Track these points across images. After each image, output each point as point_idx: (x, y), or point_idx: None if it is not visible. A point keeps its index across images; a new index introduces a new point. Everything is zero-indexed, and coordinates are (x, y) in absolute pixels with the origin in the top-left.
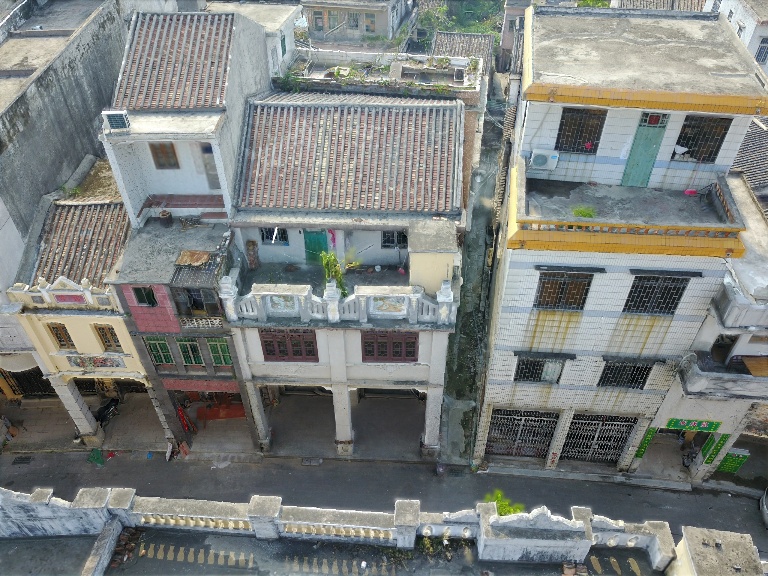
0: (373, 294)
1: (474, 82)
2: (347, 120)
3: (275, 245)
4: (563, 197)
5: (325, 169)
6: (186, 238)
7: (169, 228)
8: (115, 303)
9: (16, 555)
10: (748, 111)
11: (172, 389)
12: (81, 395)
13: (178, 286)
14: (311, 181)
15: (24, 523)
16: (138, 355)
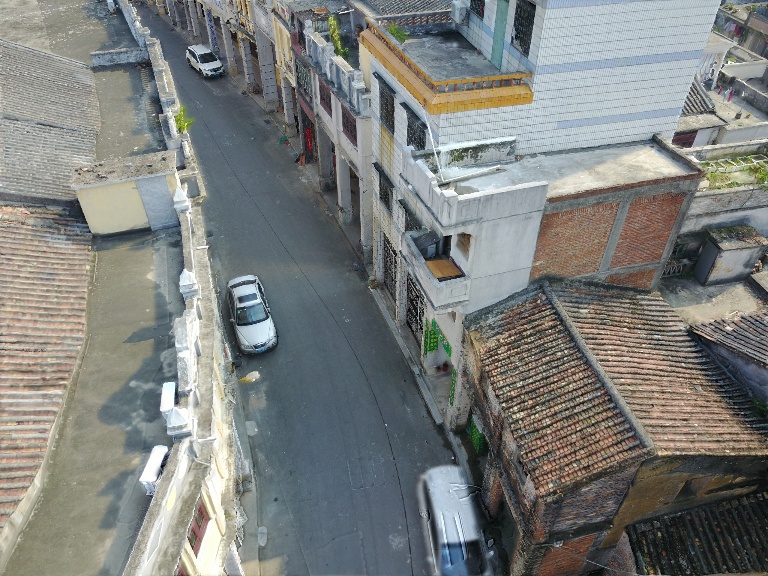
0: (336, 61)
1: None
2: None
3: None
4: (446, 46)
5: None
6: (337, 5)
7: None
8: None
9: None
10: None
11: None
12: None
13: None
14: None
15: None
16: None
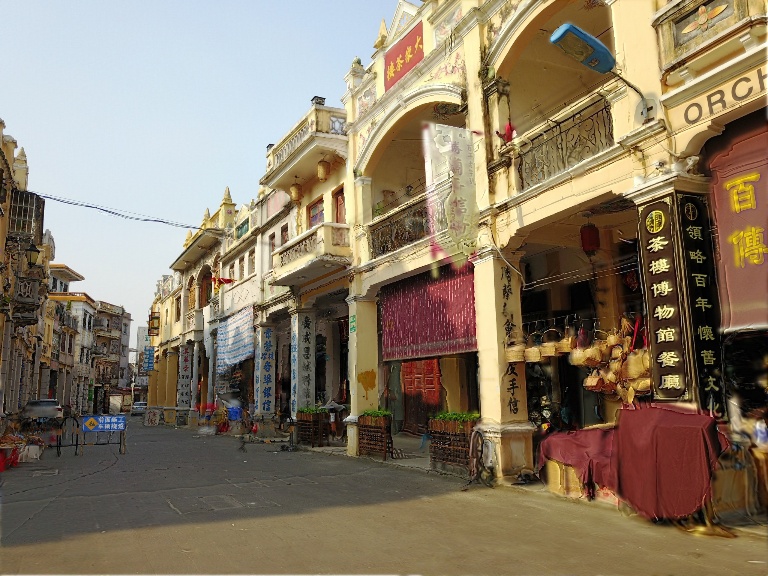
0: None
1: None
2: None
3: None
4: None
5: None
6: None
7: None
8: None
9: None
10: None
11: (51, 368)
12: None
13: None
14: None
15: None
16: None
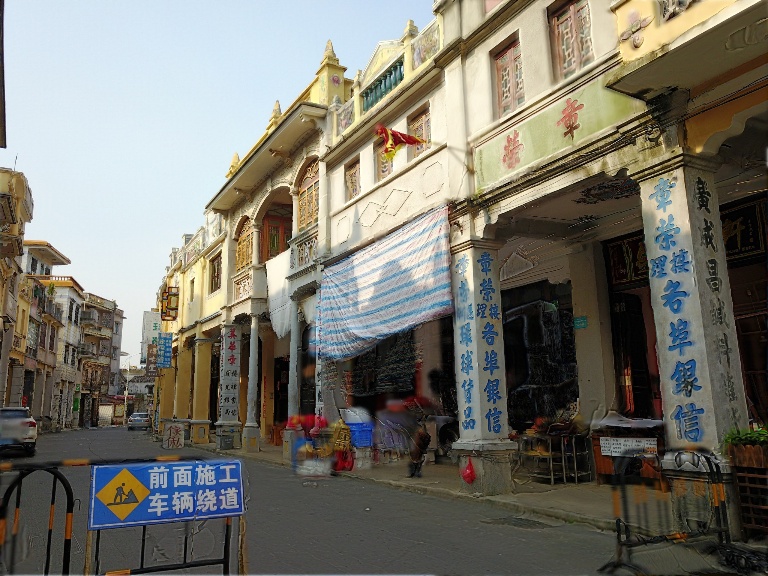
0: None
1: None
2: None
3: None
4: None
5: None
6: None
7: None
8: (29, 295)
9: None
10: (68, 260)
11: None
12: None
13: None
14: None
15: None
16: None
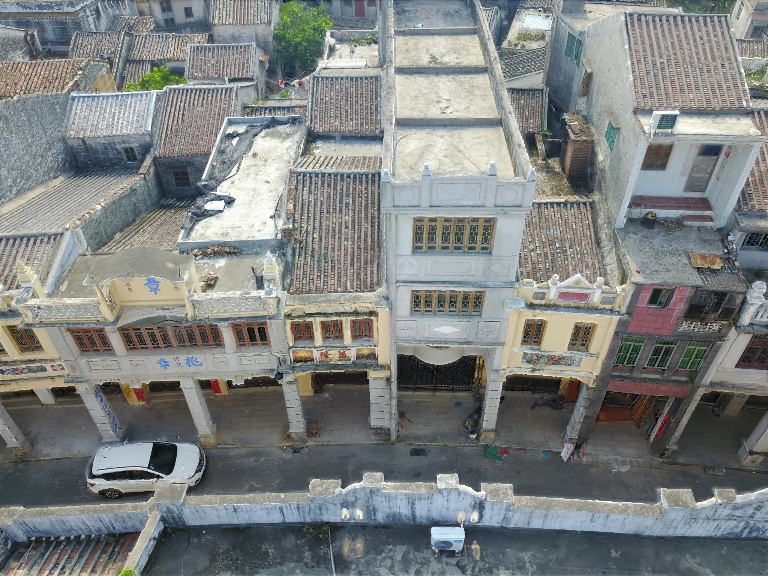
0: None
1: None
2: None
3: (753, 250)
4: None
5: None
6: (680, 240)
7: (653, 229)
8: (620, 303)
9: (732, 555)
10: None
11: (614, 390)
12: (455, 390)
13: (709, 289)
14: None
15: (755, 524)
16: (605, 355)
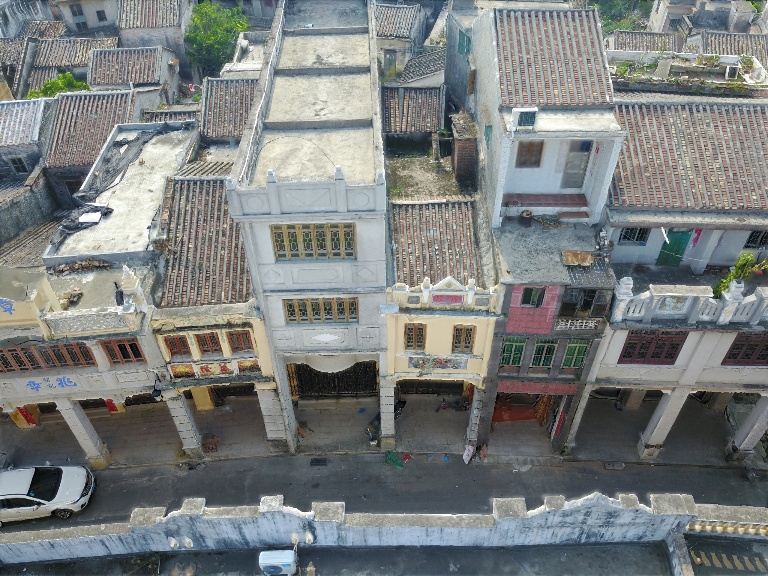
0: None
1: (764, 80)
2: (698, 118)
3: (630, 245)
4: None
5: (691, 168)
6: (554, 238)
7: (529, 228)
8: (494, 304)
9: (571, 562)
10: None
11: (504, 391)
12: (359, 396)
13: (577, 287)
14: (681, 180)
15: (590, 529)
16: (489, 357)
